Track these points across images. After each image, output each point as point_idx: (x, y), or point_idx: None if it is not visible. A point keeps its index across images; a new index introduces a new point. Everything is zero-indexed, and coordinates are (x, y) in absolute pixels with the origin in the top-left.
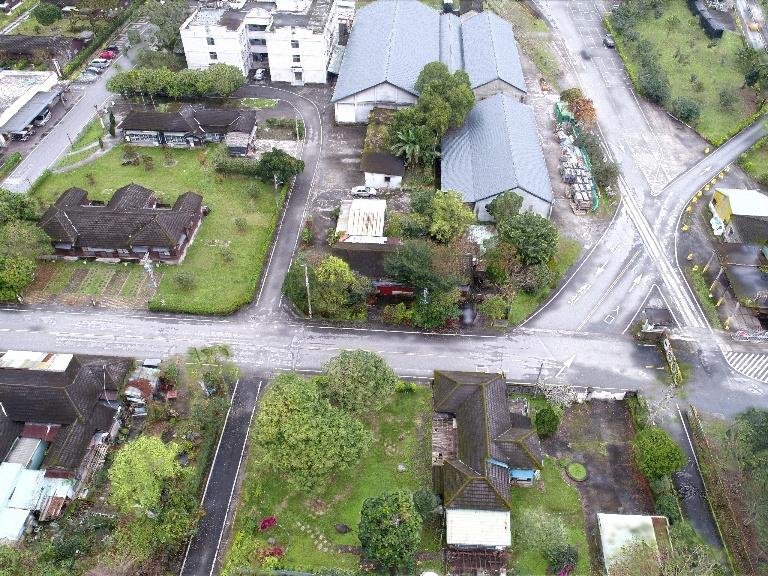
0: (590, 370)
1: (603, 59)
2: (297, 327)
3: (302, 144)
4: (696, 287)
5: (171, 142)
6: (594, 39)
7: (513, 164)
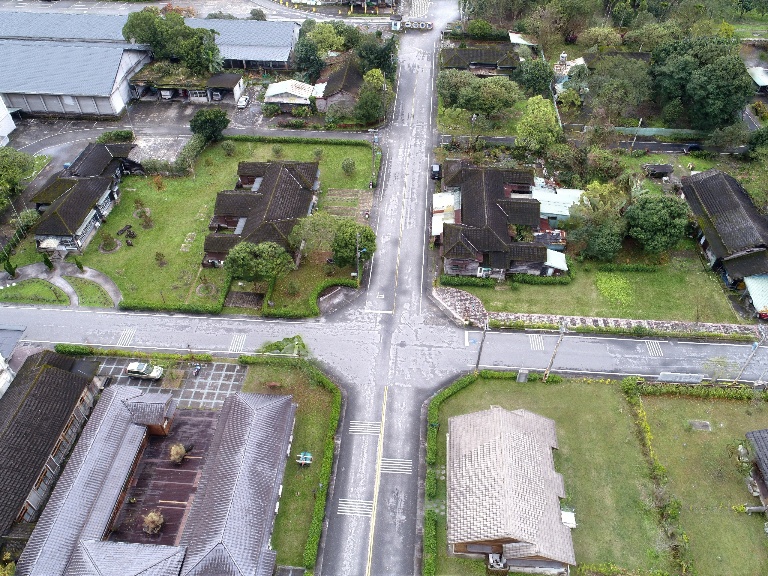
0: (424, 45)
1: (77, 5)
2: (393, 125)
3: (145, 136)
4: (363, 16)
5: (103, 211)
6: (35, 3)
7: (268, 21)
